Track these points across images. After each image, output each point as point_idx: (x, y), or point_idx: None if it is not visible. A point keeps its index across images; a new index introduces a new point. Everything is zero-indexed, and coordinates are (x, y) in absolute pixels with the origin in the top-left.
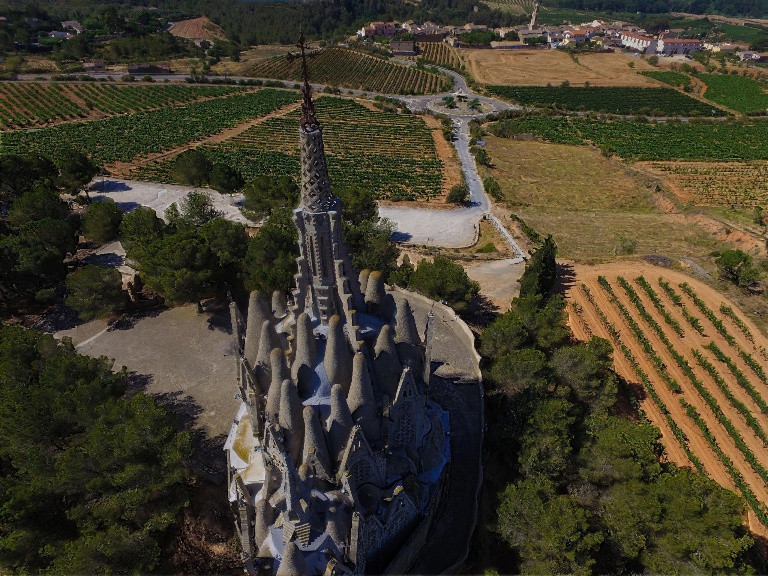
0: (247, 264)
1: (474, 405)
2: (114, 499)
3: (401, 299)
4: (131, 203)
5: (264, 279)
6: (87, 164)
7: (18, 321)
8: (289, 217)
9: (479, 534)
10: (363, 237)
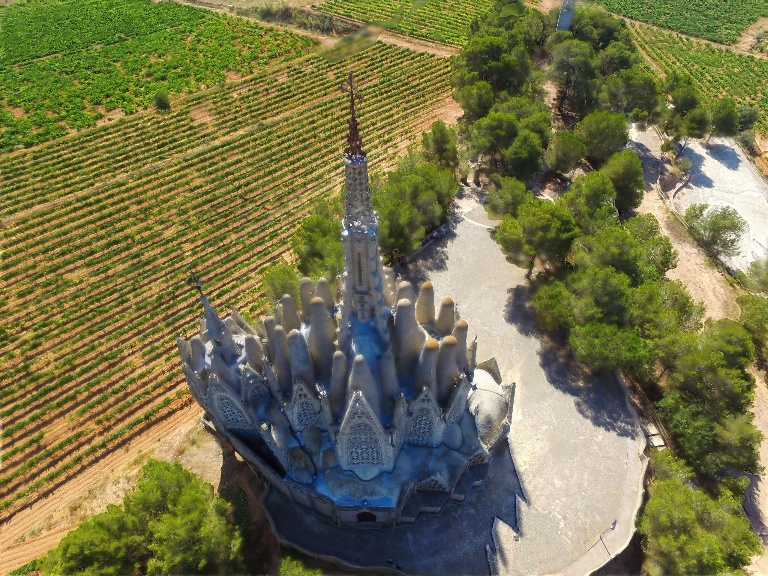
0: (572, 280)
1: (455, 571)
2: (314, 277)
3: (360, 355)
4: (709, 180)
5: (549, 298)
6: (730, 123)
7: (486, 182)
8: (759, 314)
9: (312, 568)
10: (748, 406)
